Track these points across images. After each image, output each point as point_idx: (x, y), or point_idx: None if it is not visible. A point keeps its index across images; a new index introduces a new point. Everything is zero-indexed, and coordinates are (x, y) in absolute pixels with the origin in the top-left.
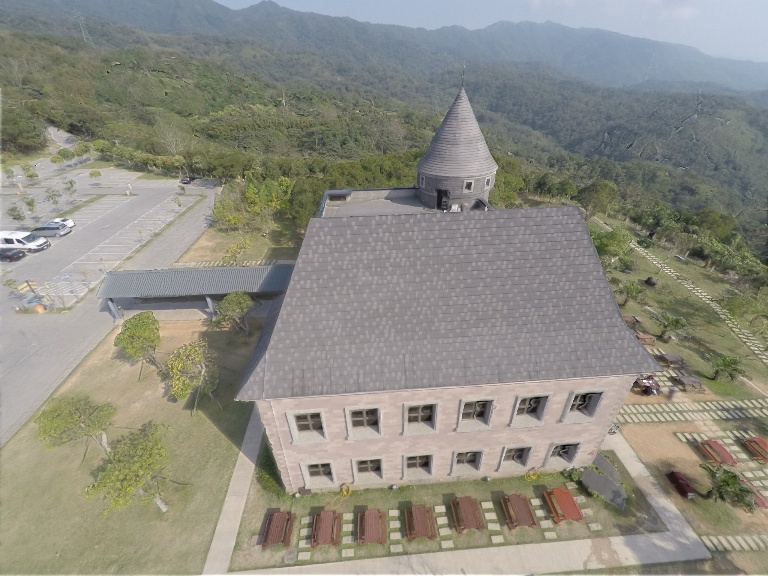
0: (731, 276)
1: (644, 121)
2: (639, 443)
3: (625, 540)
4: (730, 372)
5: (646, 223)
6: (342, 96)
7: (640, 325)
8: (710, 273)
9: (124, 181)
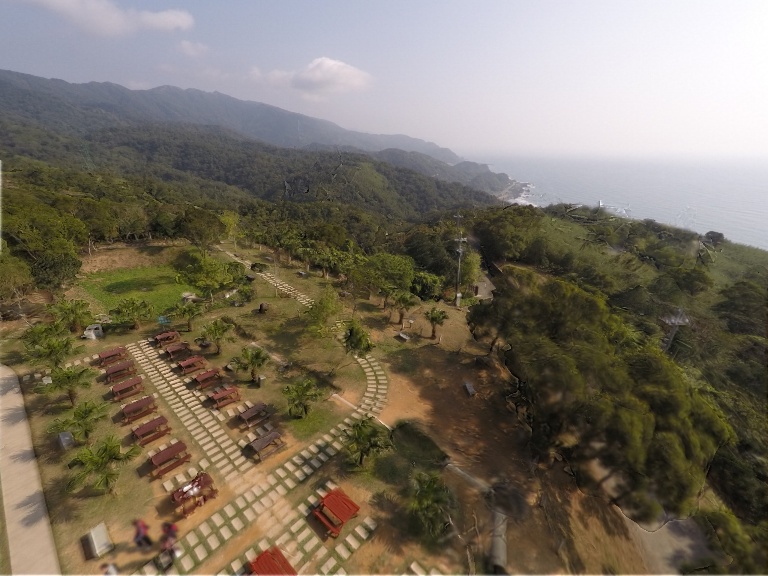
0: (343, 279)
1: (311, 171)
2: None
3: None
4: (305, 404)
5: (273, 247)
6: None
7: (233, 374)
8: (327, 281)
9: None
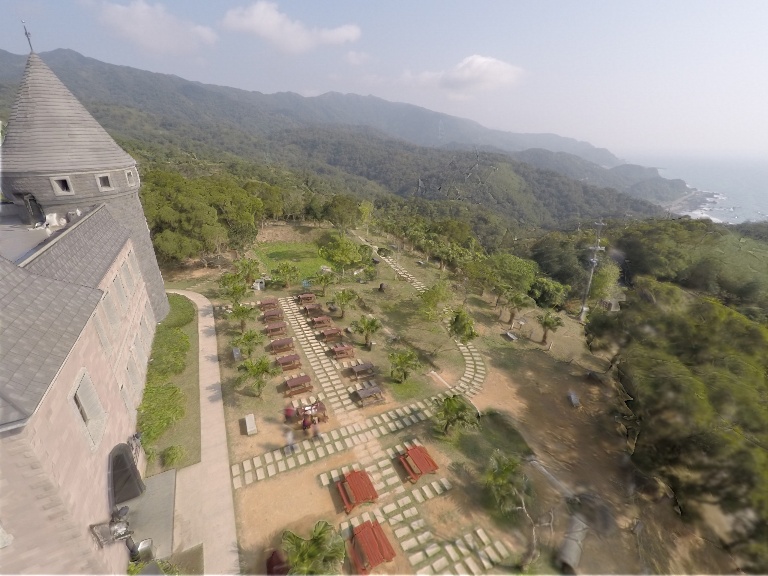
0: (459, 273)
1: (445, 170)
2: (255, 513)
3: None
4: (406, 370)
5: (399, 236)
6: (150, 147)
7: (351, 336)
8: None
9: None
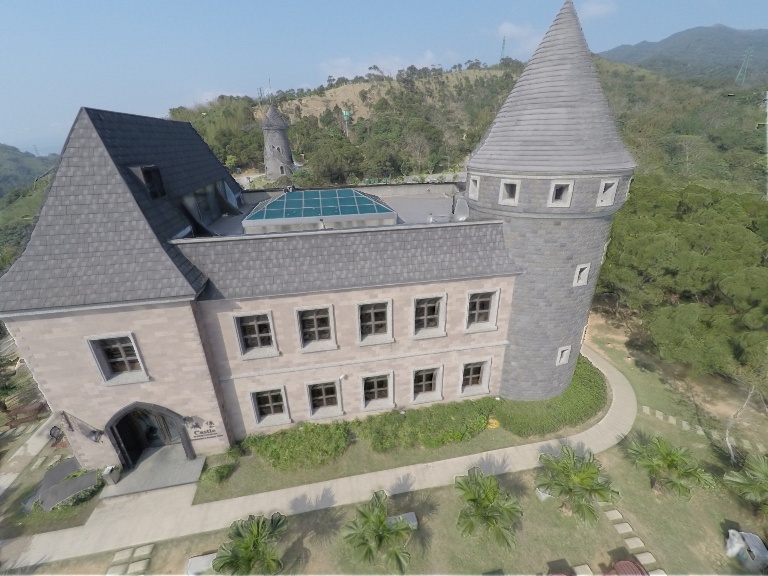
0: None
1: None
2: None
3: (2, 489)
4: None
5: None
6: None
7: None
8: None
9: None
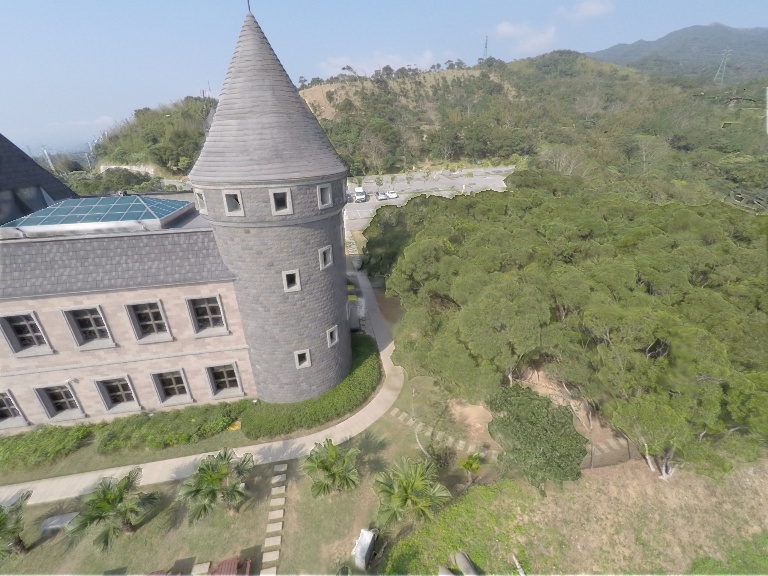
0: None
1: None
2: None
3: None
4: None
5: None
6: None
7: None
8: None
9: (489, 186)
